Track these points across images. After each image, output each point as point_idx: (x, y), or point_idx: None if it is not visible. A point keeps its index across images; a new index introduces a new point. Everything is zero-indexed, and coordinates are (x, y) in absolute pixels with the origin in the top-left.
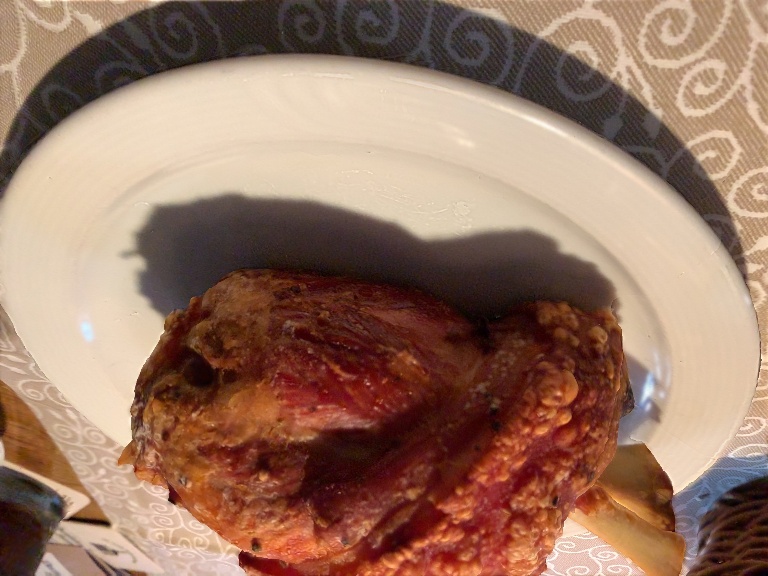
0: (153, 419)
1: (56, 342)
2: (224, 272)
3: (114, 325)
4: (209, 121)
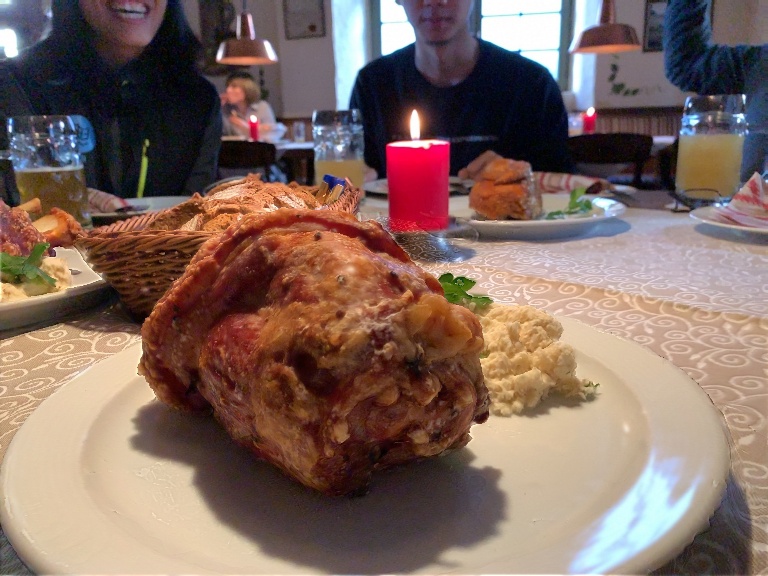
0: (345, 330)
1: (646, 511)
2: (377, 513)
3: (572, 516)
4: (142, 569)
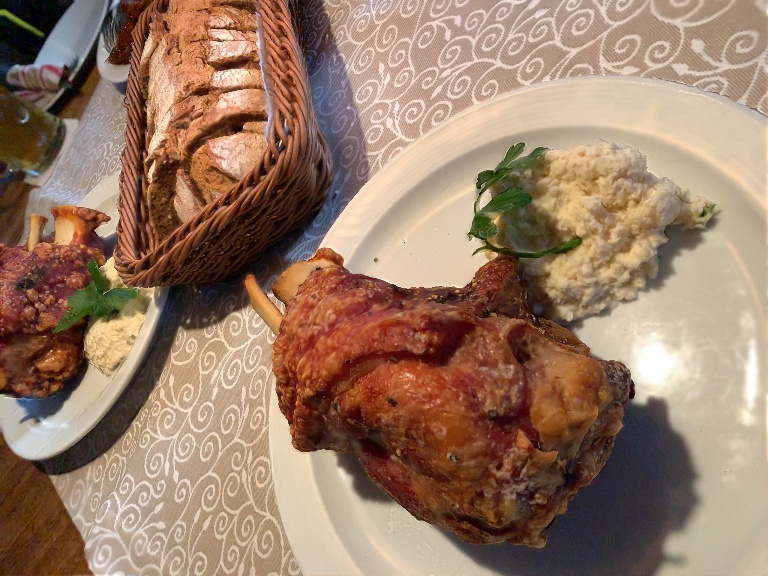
0: (494, 507)
1: None
2: (586, 507)
3: (760, 463)
4: None
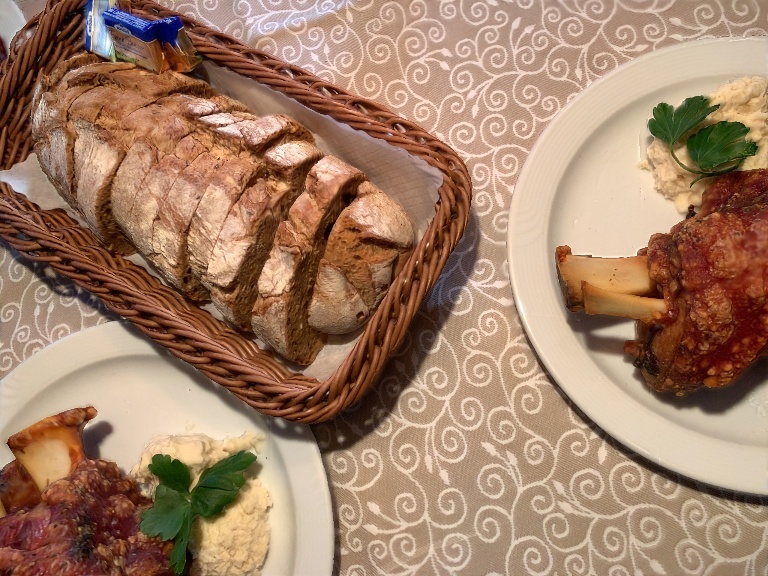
0: None
1: None
2: None
3: None
4: None
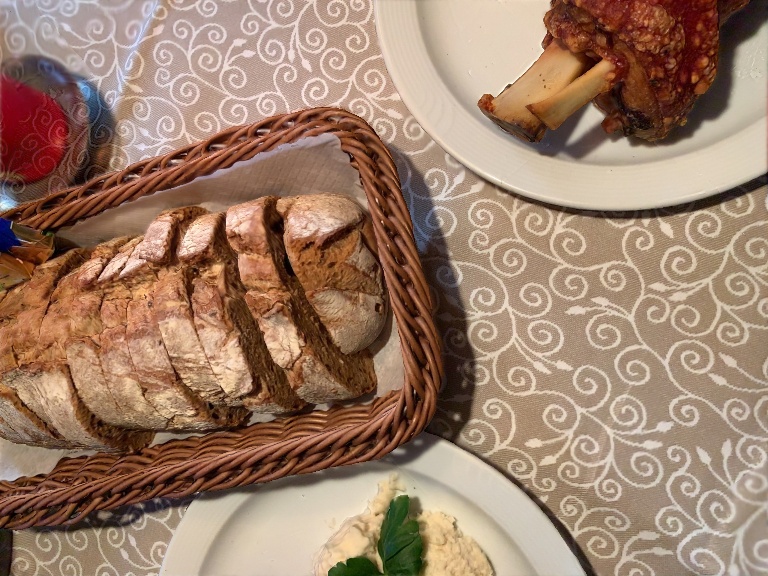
0: None
1: None
2: None
3: None
4: None
